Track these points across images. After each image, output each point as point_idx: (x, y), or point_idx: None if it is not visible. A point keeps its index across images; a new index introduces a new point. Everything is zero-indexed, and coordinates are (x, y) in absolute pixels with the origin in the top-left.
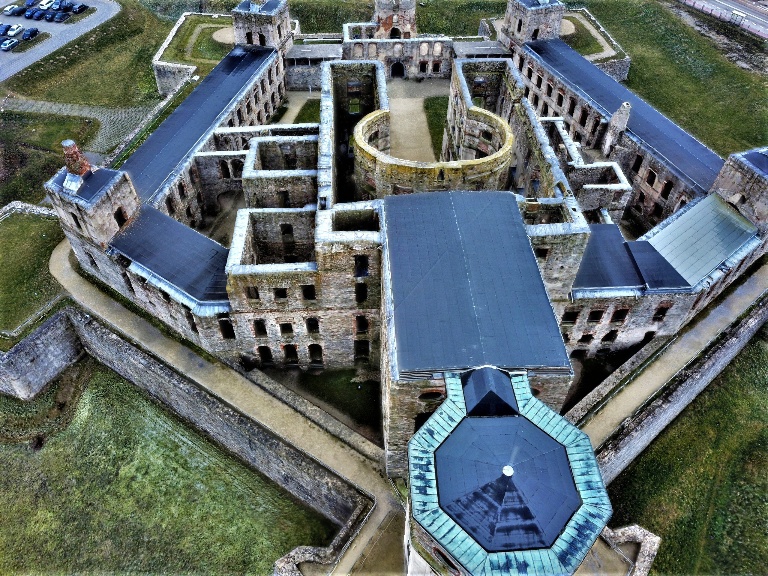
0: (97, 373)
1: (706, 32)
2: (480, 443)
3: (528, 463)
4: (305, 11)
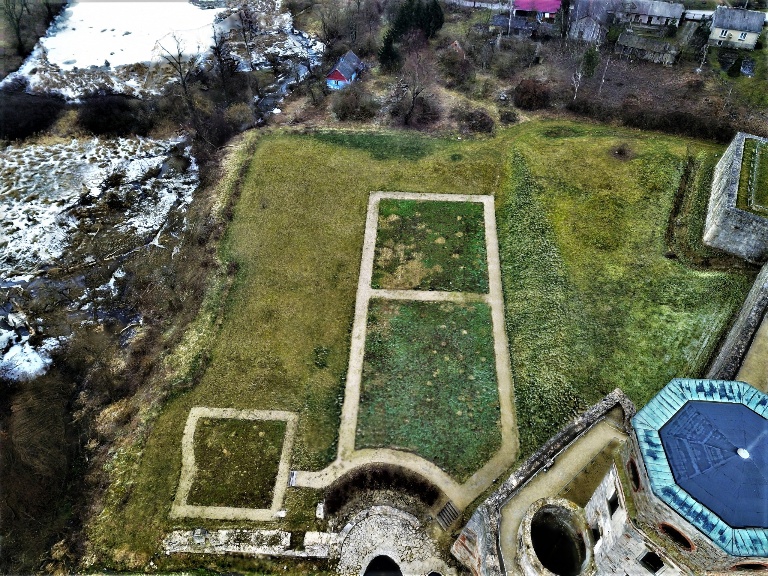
0: (745, 277)
1: None
2: (767, 440)
3: (760, 477)
4: None
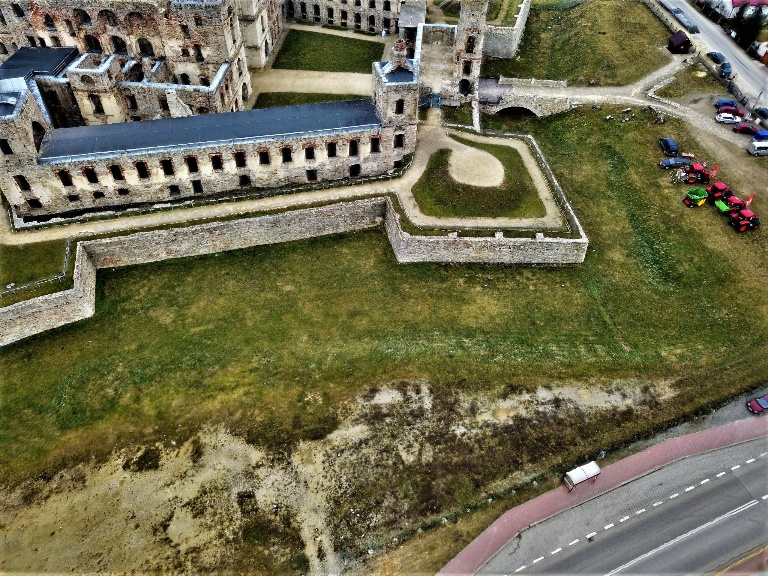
0: None
1: (526, 399)
2: None
3: None
4: (577, 49)
